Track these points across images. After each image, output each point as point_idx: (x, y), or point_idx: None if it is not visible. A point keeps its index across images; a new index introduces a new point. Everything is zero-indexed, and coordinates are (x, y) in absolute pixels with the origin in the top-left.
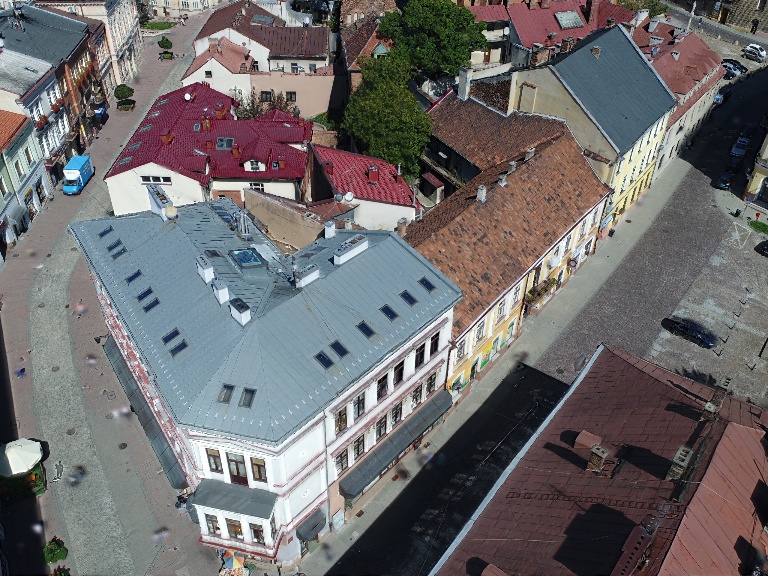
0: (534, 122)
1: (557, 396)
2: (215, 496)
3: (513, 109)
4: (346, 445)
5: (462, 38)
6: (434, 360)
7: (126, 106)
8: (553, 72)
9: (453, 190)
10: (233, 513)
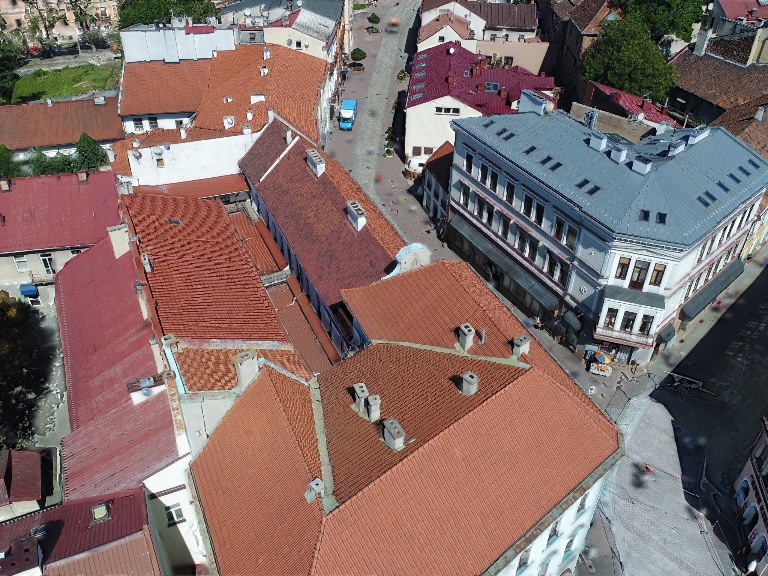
0: None
1: None
2: (620, 294)
3: (752, 61)
4: (699, 274)
5: (688, 7)
6: (744, 228)
7: (358, 67)
8: None
9: None
10: (635, 306)
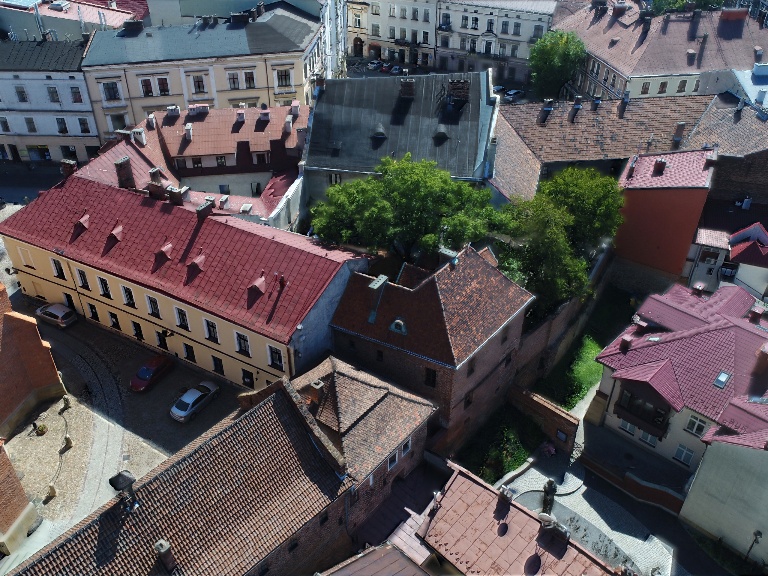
0: None
1: None
2: None
3: None
4: None
5: None
6: None
7: None
8: None
9: None
10: None
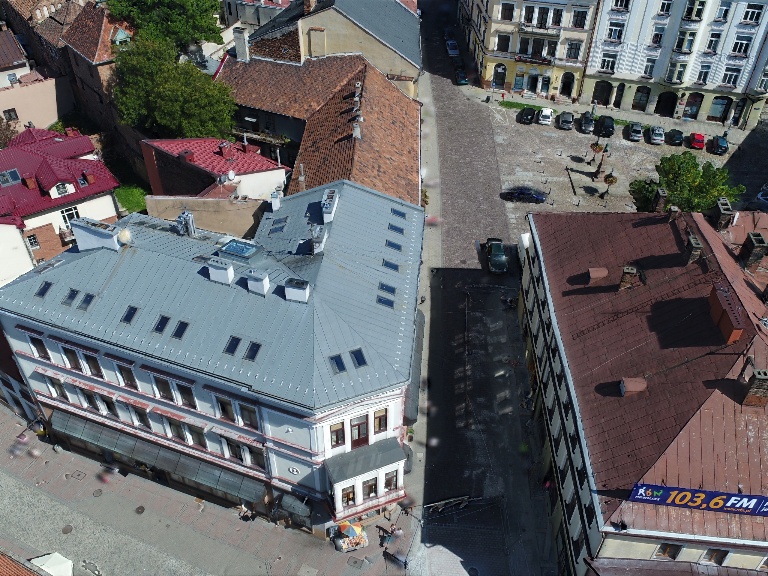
0: (332, 63)
1: (476, 280)
2: (348, 467)
3: (304, 57)
4: None
5: (203, 4)
6: None
7: None
8: (339, 11)
9: (269, 151)
10: (373, 472)
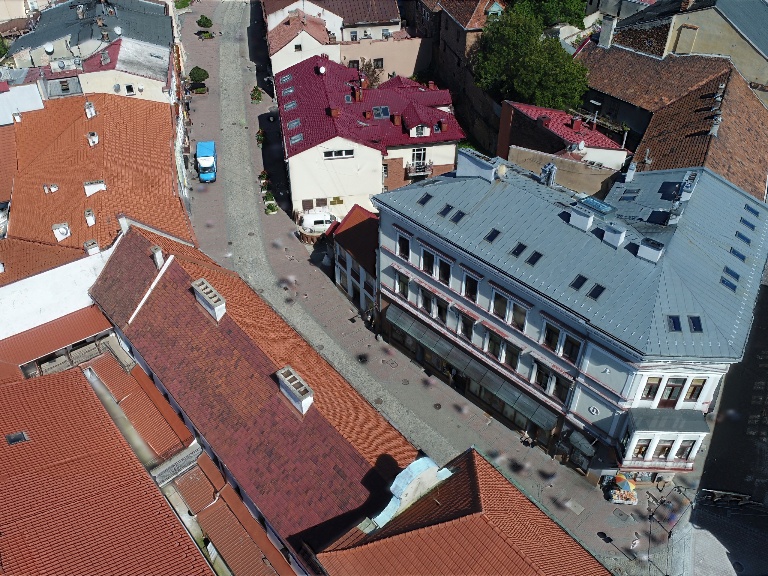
0: (695, 62)
1: None
2: (652, 421)
3: (667, 52)
4: None
5: None
6: None
7: (201, 89)
8: (719, 12)
9: None
10: (673, 433)
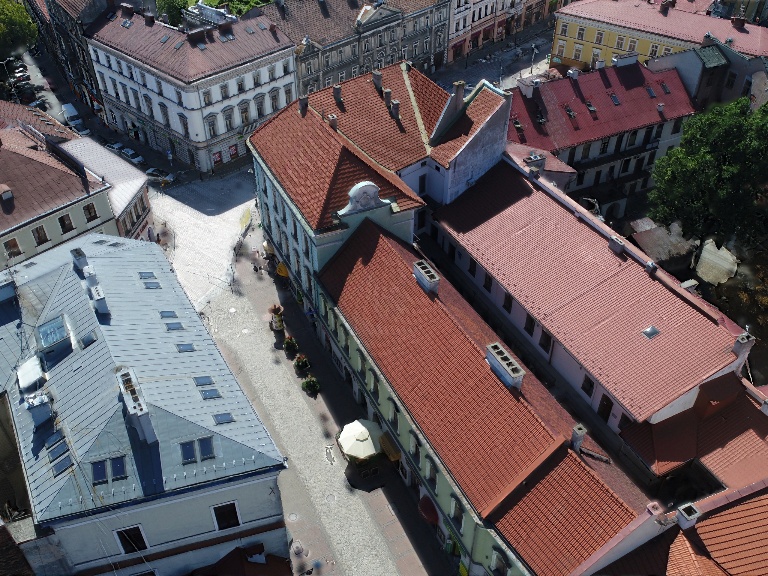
0: None
1: None
2: None
3: None
4: None
5: None
6: None
7: None
8: None
9: None
10: None
